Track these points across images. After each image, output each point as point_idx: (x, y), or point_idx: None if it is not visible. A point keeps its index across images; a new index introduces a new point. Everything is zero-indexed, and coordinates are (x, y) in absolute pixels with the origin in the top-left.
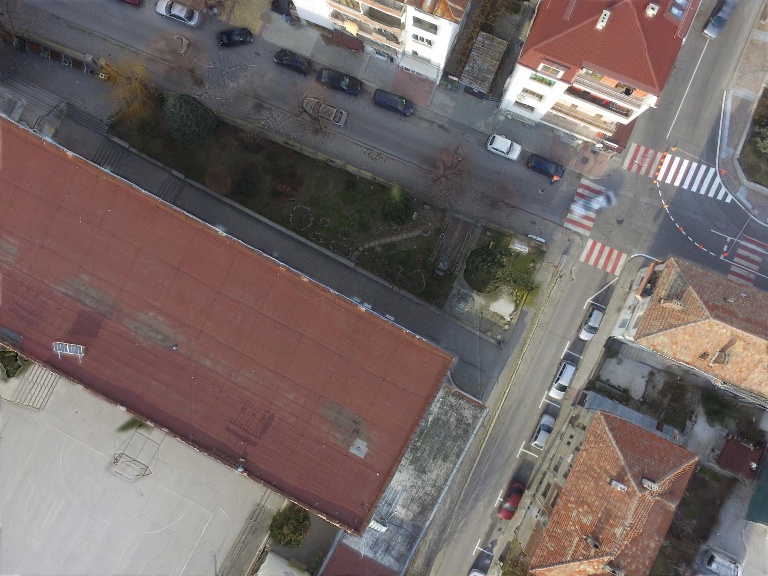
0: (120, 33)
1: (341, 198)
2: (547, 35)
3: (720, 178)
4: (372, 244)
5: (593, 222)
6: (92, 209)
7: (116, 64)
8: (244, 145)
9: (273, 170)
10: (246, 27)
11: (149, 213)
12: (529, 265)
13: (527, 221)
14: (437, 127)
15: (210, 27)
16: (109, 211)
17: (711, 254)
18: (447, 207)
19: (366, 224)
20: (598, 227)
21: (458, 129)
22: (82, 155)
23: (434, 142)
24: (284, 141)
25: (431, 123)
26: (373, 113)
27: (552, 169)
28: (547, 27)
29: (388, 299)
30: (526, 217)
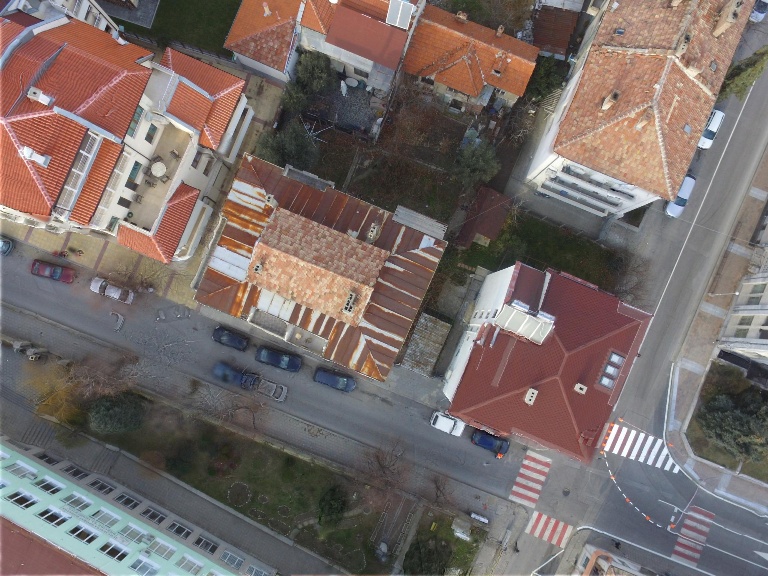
0: (53, 309)
1: (280, 475)
2: (476, 401)
3: (667, 449)
4: (312, 522)
5: (539, 494)
6: (4, 562)
7: (48, 343)
8: (180, 426)
9: (210, 449)
10: (184, 303)
11: (64, 568)
12: (472, 545)
13: (471, 496)
14: (380, 401)
15: (147, 303)
16: (22, 565)
17: (658, 526)
18: (388, 488)
19: (306, 502)
20: (544, 499)
21: (402, 402)
22: (11, 434)
23: (377, 416)
24: (221, 424)
25: (374, 397)
26: (314, 387)
27: (497, 445)
28: (476, 394)
29: (328, 575)
30: (470, 492)
